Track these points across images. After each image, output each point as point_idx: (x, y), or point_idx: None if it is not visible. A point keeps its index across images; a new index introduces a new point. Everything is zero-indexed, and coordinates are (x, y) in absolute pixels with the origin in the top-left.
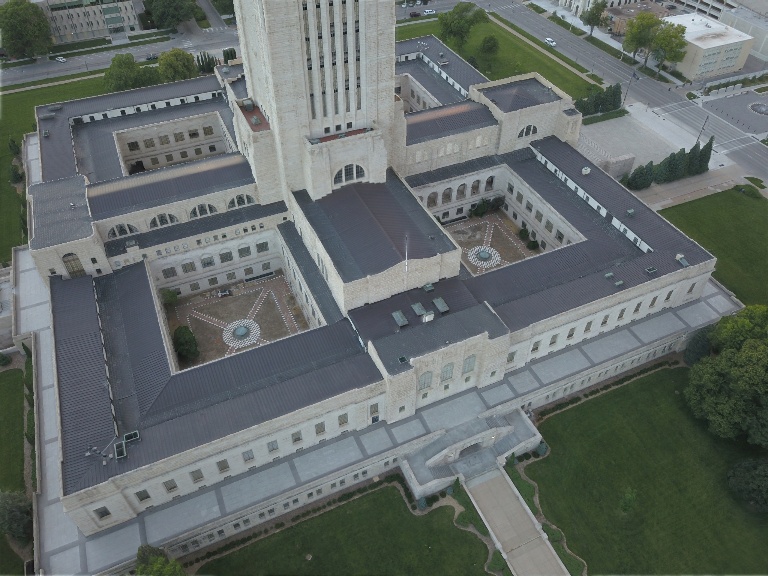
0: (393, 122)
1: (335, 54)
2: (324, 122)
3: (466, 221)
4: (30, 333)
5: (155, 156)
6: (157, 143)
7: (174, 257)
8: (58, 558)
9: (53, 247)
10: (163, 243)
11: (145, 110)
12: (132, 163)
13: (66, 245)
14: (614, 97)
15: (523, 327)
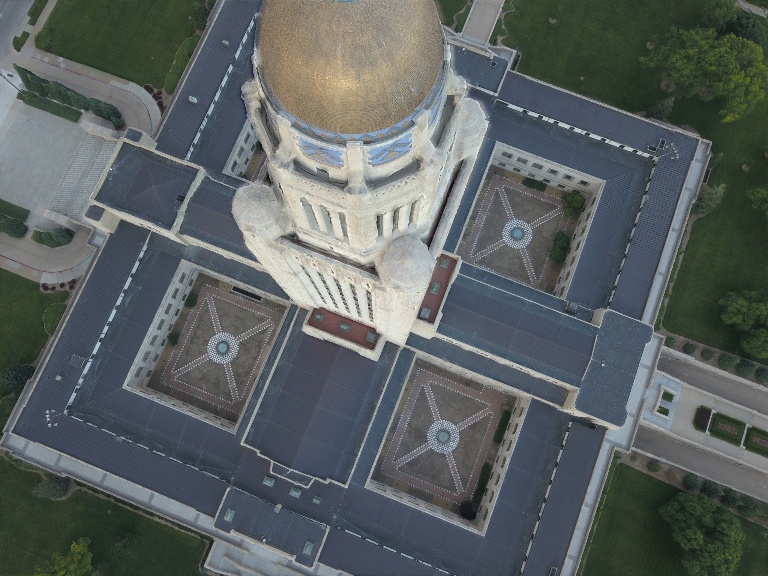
0: None
1: None
2: None
3: None
4: None
5: None
6: None
7: None
8: (697, 156)
9: (638, 320)
10: (548, 295)
11: None
12: None
13: None
14: None
15: None
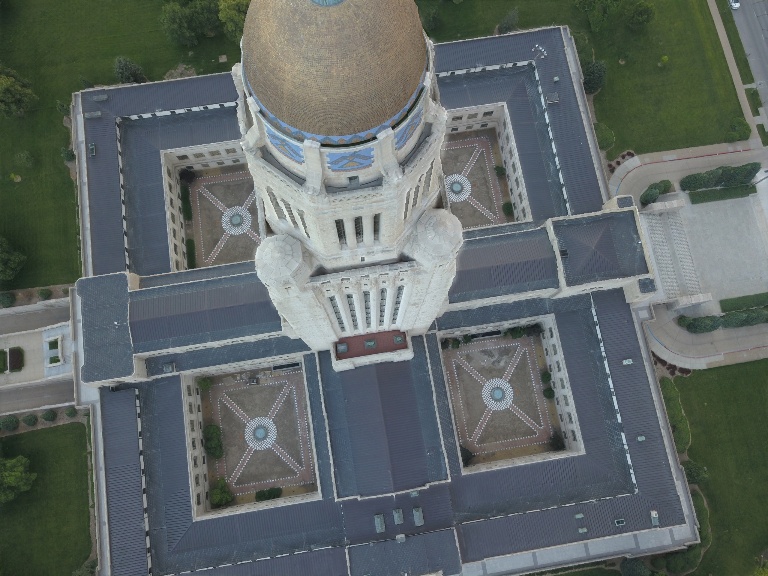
0: (429, 326)
1: (370, 317)
2: (354, 332)
3: (498, 338)
4: (88, 405)
5: (206, 163)
6: (207, 155)
7: (207, 371)
8: None
9: (100, 382)
10: (197, 368)
11: (196, 110)
12: (182, 167)
13: (111, 380)
14: (746, 176)
15: (479, 557)
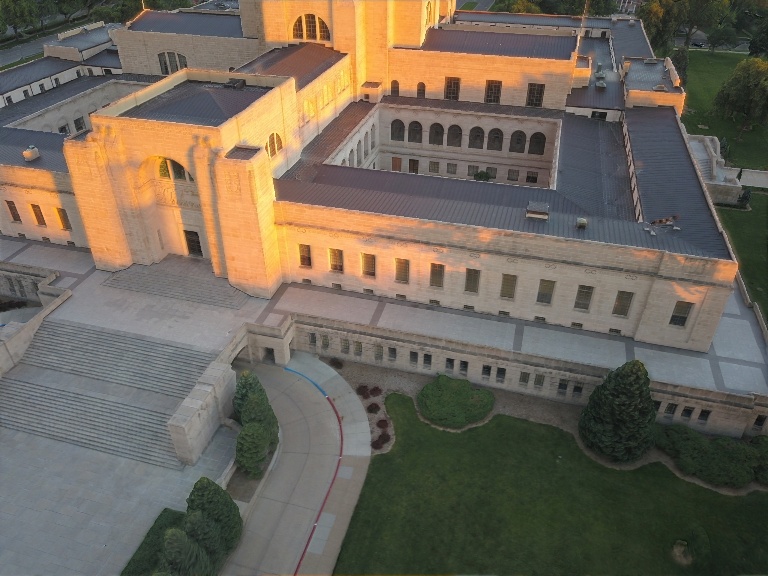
0: None
1: None
2: None
3: None
4: None
5: None
6: None
7: None
8: None
9: None
10: None
11: None
12: None
13: None
14: None
15: (39, 63)
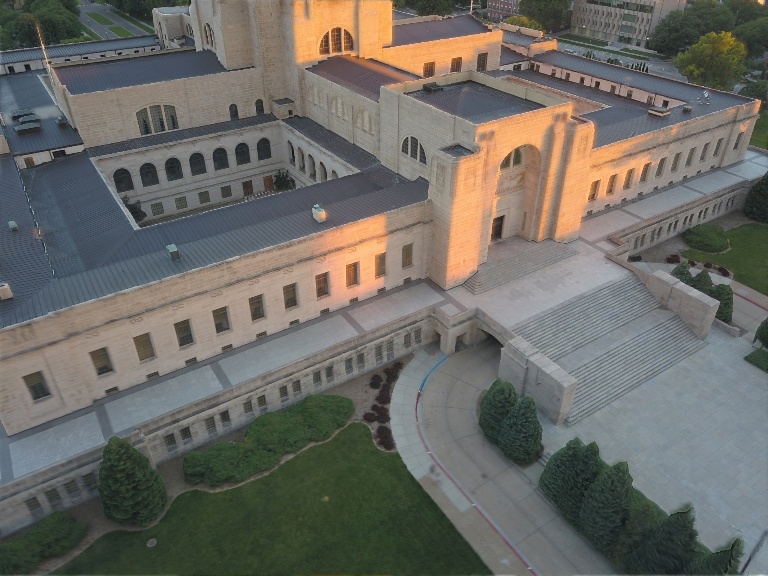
0: (255, 2)
1: None
2: None
3: None
4: None
5: None
6: None
7: None
8: None
9: None
10: None
11: None
12: None
13: (158, 14)
14: None
15: None
